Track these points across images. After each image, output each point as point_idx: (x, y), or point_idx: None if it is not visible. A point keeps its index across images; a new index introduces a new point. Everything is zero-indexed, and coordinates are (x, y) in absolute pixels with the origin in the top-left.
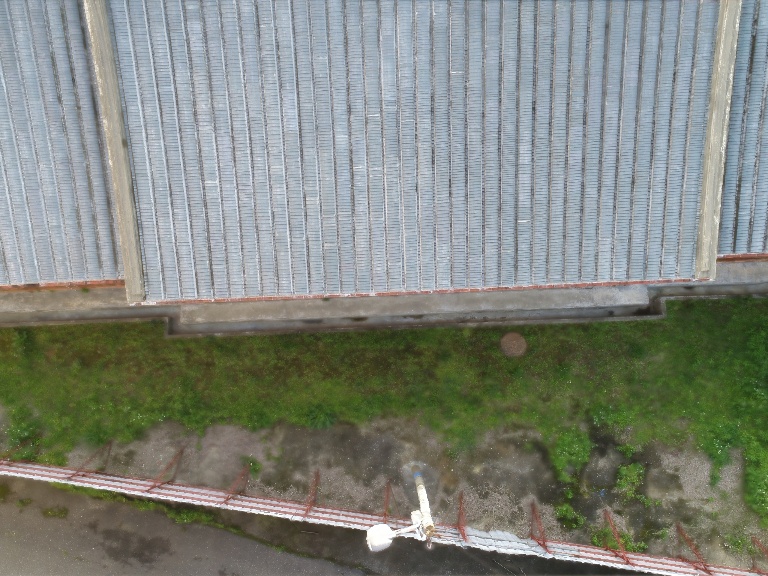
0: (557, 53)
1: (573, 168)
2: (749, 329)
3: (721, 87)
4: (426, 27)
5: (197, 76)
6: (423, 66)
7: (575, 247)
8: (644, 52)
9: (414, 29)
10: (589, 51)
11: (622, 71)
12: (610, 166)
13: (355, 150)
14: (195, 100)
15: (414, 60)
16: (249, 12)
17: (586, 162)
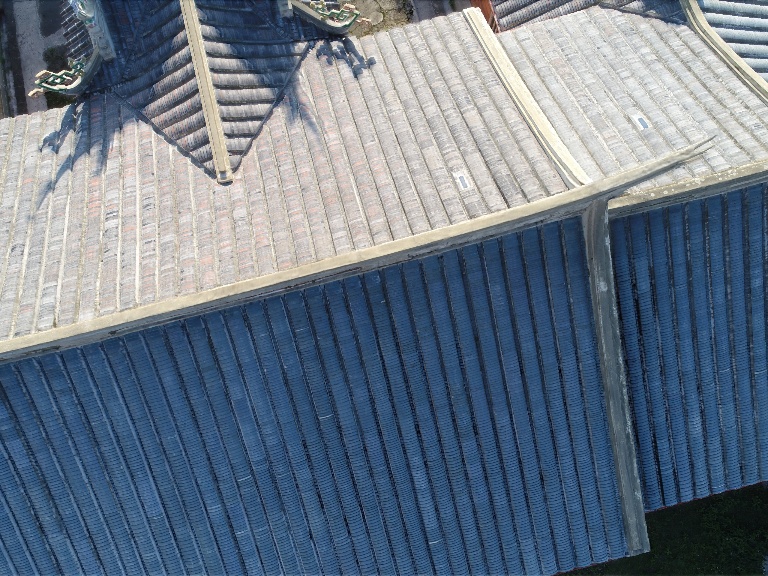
0: (429, 376)
1: (475, 481)
2: (700, 508)
3: (612, 378)
4: (279, 382)
5: (32, 492)
6: (286, 420)
7: (496, 554)
8: (522, 358)
9: (267, 384)
10: (464, 366)
11: (504, 378)
12: (514, 471)
13: (232, 517)
14: (37, 513)
15: (275, 414)
16: (74, 414)
17: (487, 472)
